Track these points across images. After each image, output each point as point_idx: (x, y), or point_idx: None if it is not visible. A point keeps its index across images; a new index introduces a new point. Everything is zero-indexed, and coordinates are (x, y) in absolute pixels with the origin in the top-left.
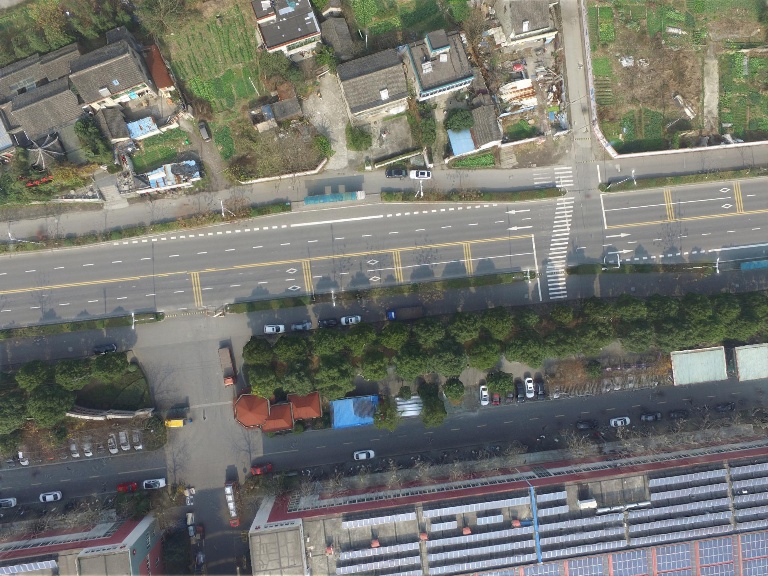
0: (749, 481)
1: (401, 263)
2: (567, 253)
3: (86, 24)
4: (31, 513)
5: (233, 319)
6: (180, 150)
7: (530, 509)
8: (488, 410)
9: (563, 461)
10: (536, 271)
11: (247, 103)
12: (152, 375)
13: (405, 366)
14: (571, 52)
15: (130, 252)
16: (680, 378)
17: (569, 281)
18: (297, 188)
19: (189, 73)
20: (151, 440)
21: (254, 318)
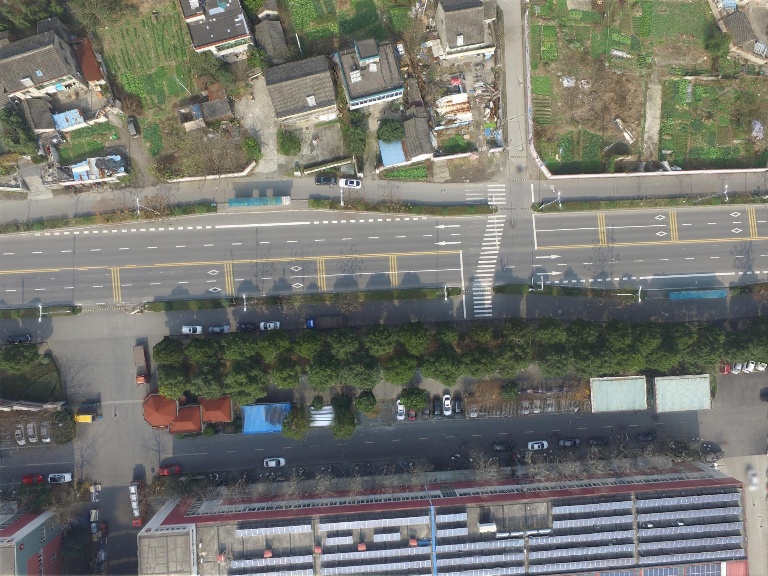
0: (655, 515)
1: (325, 271)
2: (495, 271)
3: (16, 13)
4: None
5: (151, 317)
6: (108, 144)
7: (429, 529)
8: (404, 425)
9: (474, 482)
10: (462, 288)
11: (178, 101)
12: (65, 368)
13: (315, 376)
14: (512, 69)
15: (51, 244)
16: (598, 405)
17: (495, 300)
18: (224, 189)
19: (121, 68)
20: (59, 434)
21: (172, 317)
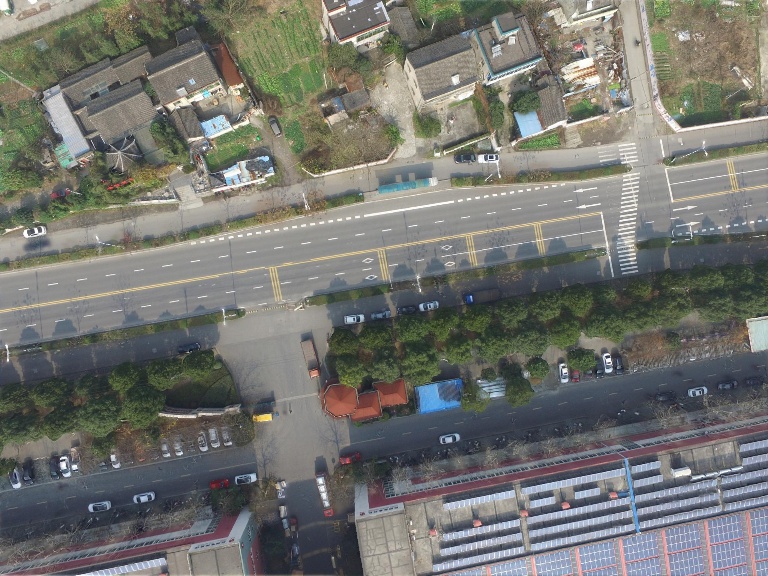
0: None
1: (474, 247)
2: (636, 228)
3: (157, 26)
4: (127, 515)
5: (313, 311)
6: (252, 147)
7: (625, 480)
8: (568, 387)
9: (647, 433)
10: None
11: (315, 96)
12: (236, 371)
13: (491, 347)
14: (628, 29)
15: (208, 251)
16: (757, 345)
17: (639, 256)
18: None
19: (257, 70)
20: (240, 436)
21: (333, 309)
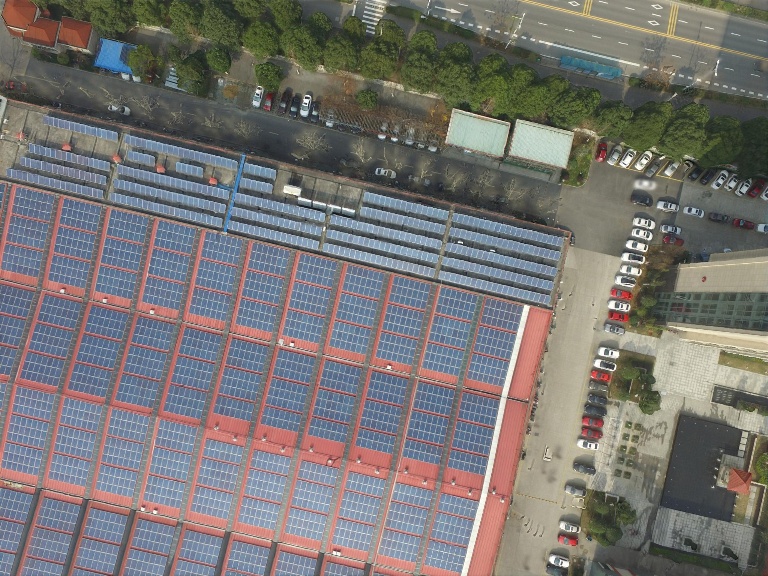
0: (468, 233)
1: None
2: None
3: None
4: None
5: None
6: None
7: (235, 177)
8: (258, 114)
9: None
10: None
11: None
12: None
13: (172, 9)
14: None
15: None
16: (454, 138)
17: None
18: None
19: None
20: None
21: None
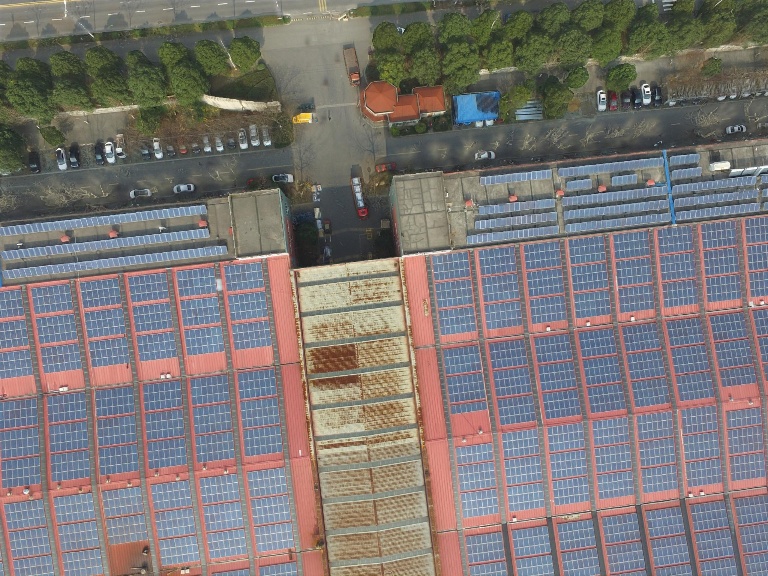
0: None
1: None
2: None
3: None
4: (166, 202)
5: (356, 24)
6: None
7: (663, 173)
8: (605, 117)
9: None
10: None
11: None
12: (279, 76)
13: (533, 45)
14: None
15: None
16: None
17: None
18: None
19: None
20: (280, 136)
21: (376, 24)
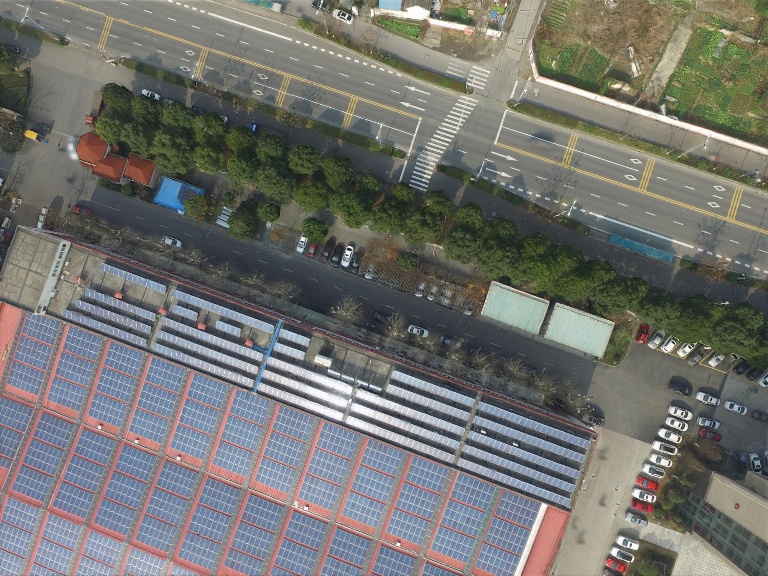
0: (492, 423)
1: (287, 89)
2: (446, 150)
3: None
4: None
5: (122, 72)
6: None
7: (270, 340)
8: (301, 259)
9: (339, 332)
10: (408, 153)
11: None
12: (36, 89)
13: (230, 164)
14: None
15: None
16: (490, 310)
17: (435, 177)
18: None
19: None
20: (8, 141)
21: (140, 79)
